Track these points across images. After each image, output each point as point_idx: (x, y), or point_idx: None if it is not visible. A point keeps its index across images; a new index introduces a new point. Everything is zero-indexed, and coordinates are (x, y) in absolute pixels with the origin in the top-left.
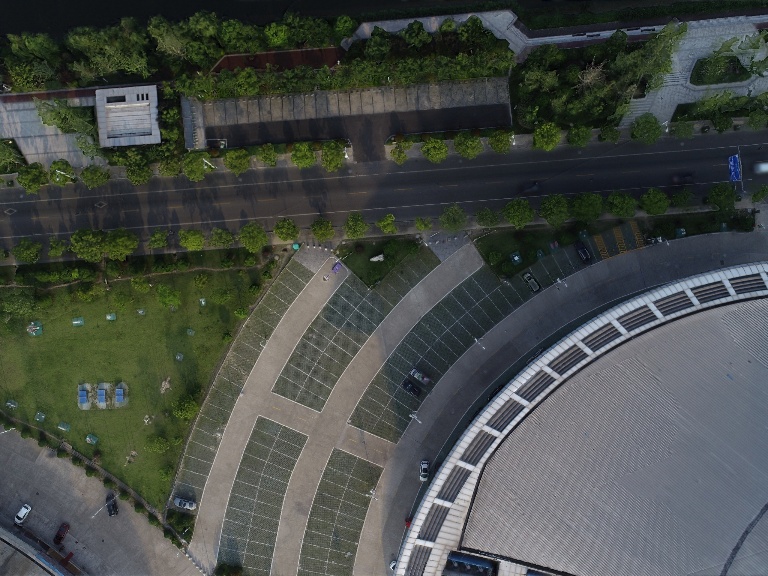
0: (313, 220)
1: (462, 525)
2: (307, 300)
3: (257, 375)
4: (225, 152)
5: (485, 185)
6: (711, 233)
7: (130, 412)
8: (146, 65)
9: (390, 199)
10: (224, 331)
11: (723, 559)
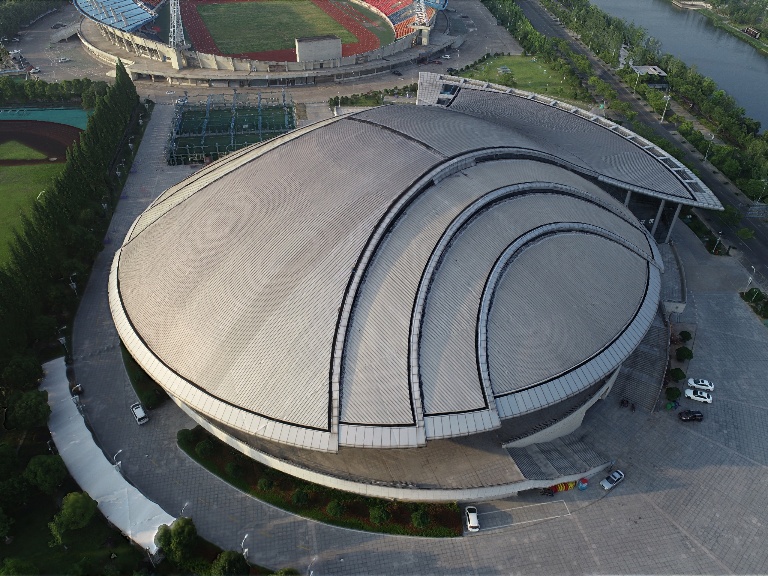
0: None
1: None
2: None
3: None
4: (644, 96)
5: None
6: (696, 235)
7: None
8: (677, 71)
9: None
10: None
11: None
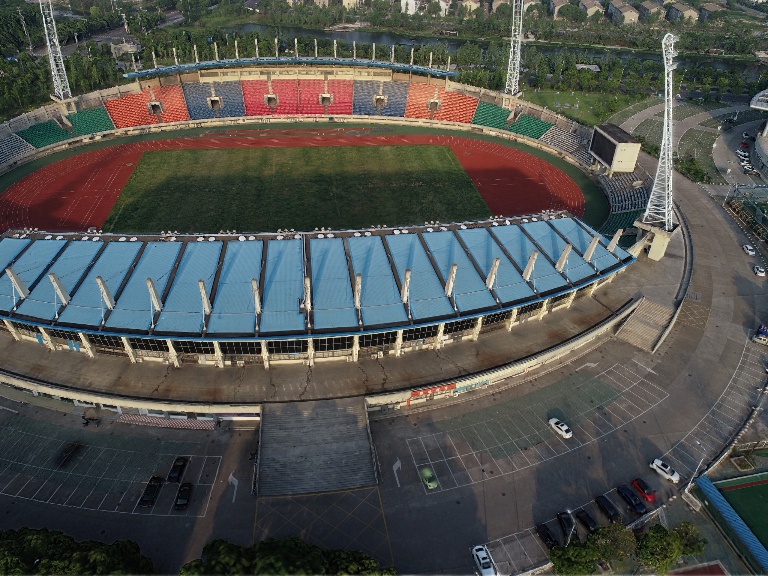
0: None
1: None
2: None
3: None
4: None
5: None
6: None
7: None
8: None
9: (702, 96)
10: None
11: None
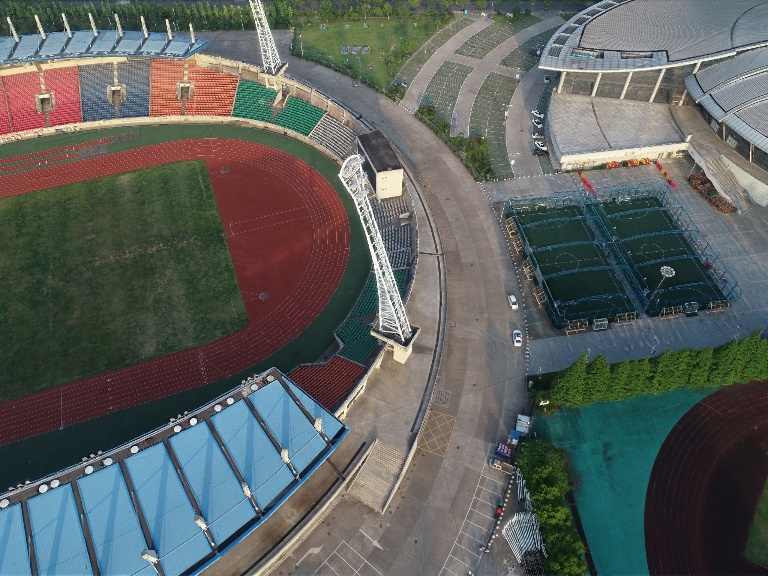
0: (474, 8)
1: (578, 41)
2: (472, 28)
3: (445, 48)
4: None
5: (562, 3)
6: None
7: (371, 56)
8: None
9: (513, 5)
10: (427, 34)
11: (729, 27)
